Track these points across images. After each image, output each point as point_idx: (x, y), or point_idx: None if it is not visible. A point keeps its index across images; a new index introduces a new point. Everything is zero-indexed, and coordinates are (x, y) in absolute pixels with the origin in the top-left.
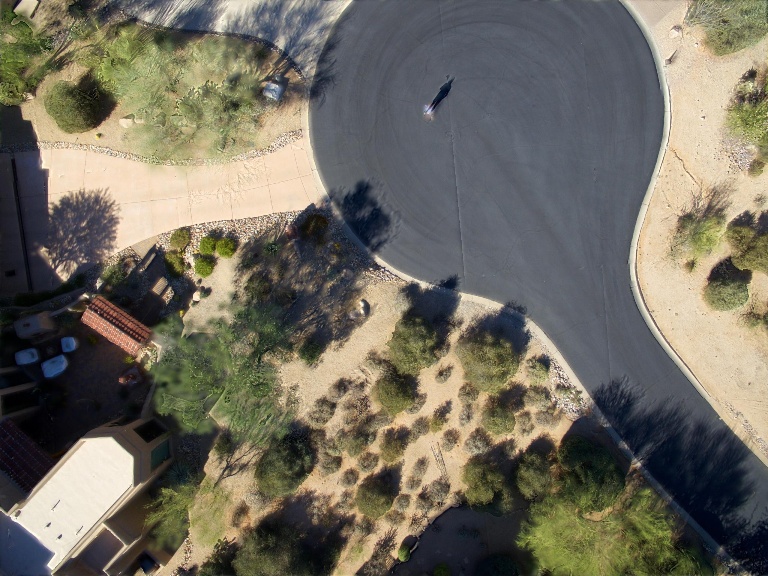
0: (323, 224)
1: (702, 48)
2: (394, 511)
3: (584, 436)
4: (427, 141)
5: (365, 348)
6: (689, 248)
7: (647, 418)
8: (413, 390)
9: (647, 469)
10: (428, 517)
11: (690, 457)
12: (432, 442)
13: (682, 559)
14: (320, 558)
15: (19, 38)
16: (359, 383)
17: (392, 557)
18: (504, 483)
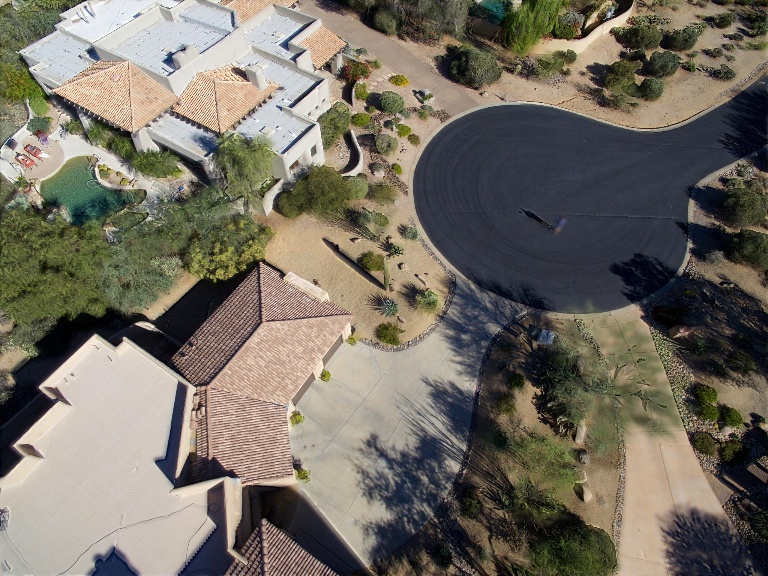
0: None
1: (493, 84)
2: None
3: None
4: (573, 231)
5: (761, 289)
6: (624, 103)
7: (743, 134)
8: None
9: None
10: None
11: (760, 117)
12: None
13: None
14: None
15: (557, 567)
16: None
17: None
18: None
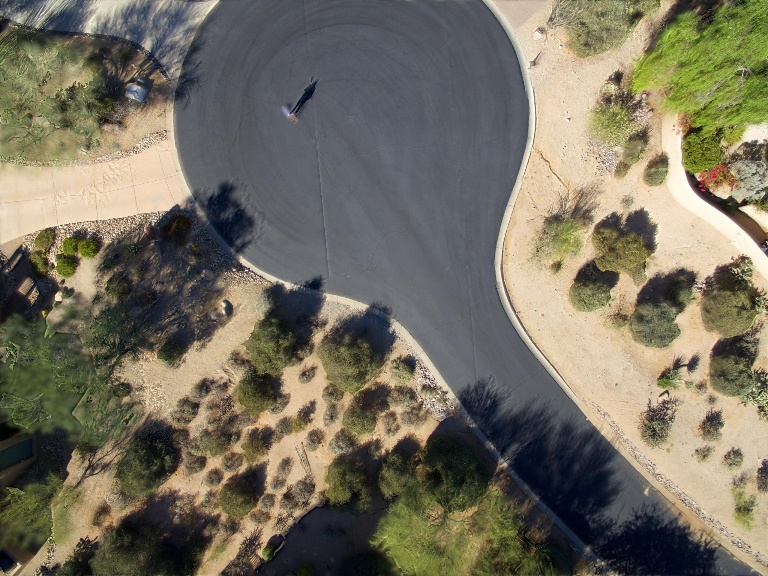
0: (185, 225)
1: (566, 50)
2: (259, 511)
3: (450, 436)
4: (291, 142)
5: (228, 348)
6: (554, 249)
7: (513, 418)
8: (277, 390)
9: (514, 469)
10: (294, 517)
11: (557, 457)
12: (296, 442)
13: (525, 559)
14: (182, 557)
15: None
16: (222, 383)
17: (258, 556)
18: (365, 483)
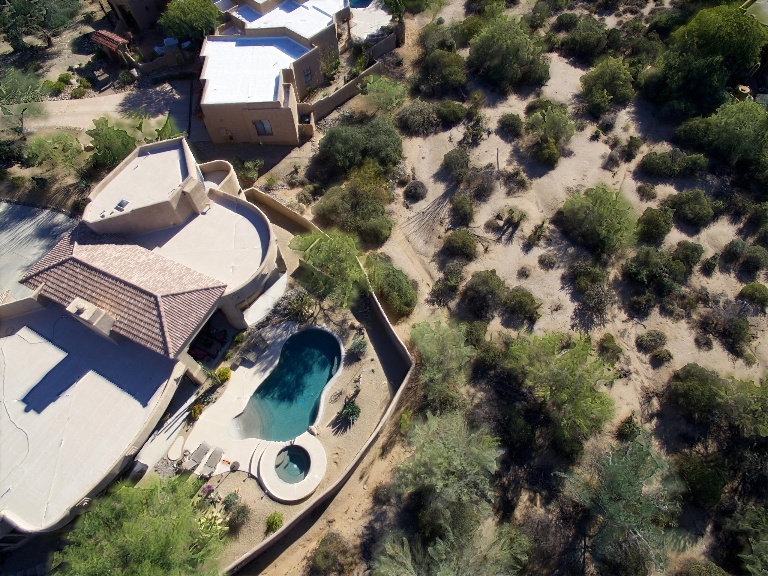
0: None
1: None
2: None
3: None
4: None
5: None
6: None
7: None
8: None
9: None
10: None
11: None
12: None
13: None
14: None
15: None
16: (5, 41)
17: None
18: None
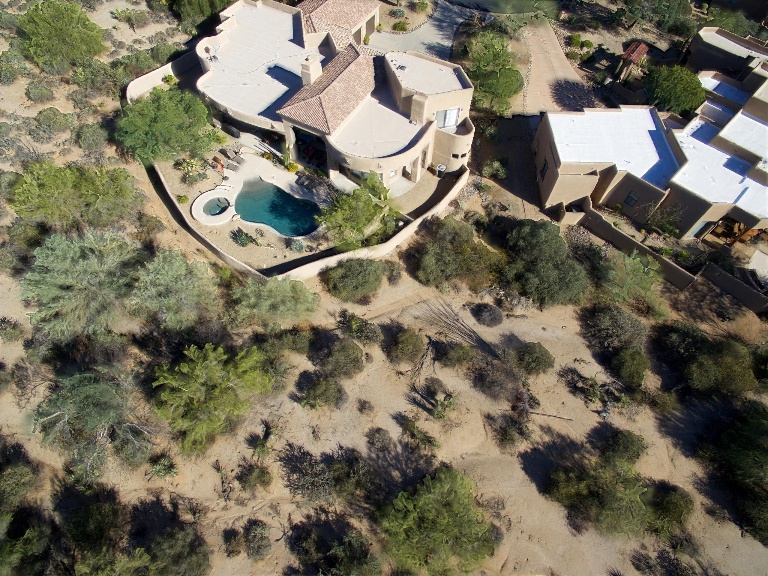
0: None
1: None
2: None
3: None
4: None
5: (612, 5)
6: None
7: None
8: None
9: None
10: None
11: None
12: None
13: None
14: None
15: None
16: (629, 8)
17: None
18: None
